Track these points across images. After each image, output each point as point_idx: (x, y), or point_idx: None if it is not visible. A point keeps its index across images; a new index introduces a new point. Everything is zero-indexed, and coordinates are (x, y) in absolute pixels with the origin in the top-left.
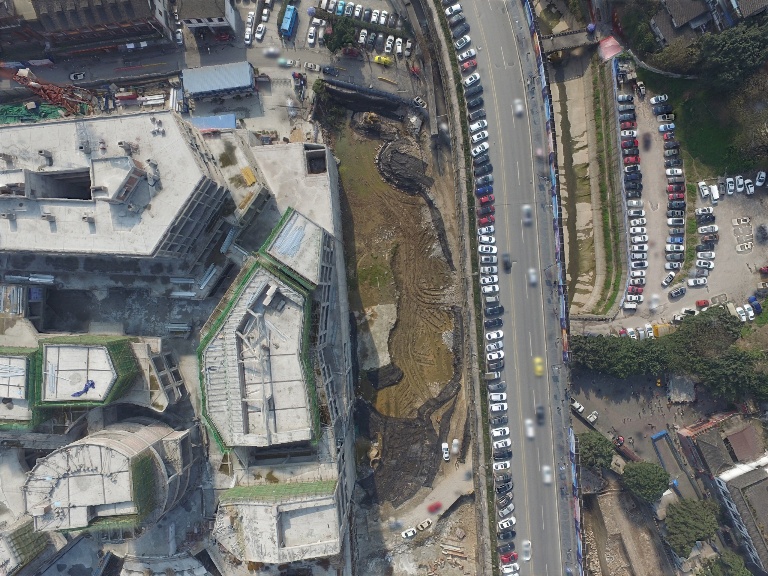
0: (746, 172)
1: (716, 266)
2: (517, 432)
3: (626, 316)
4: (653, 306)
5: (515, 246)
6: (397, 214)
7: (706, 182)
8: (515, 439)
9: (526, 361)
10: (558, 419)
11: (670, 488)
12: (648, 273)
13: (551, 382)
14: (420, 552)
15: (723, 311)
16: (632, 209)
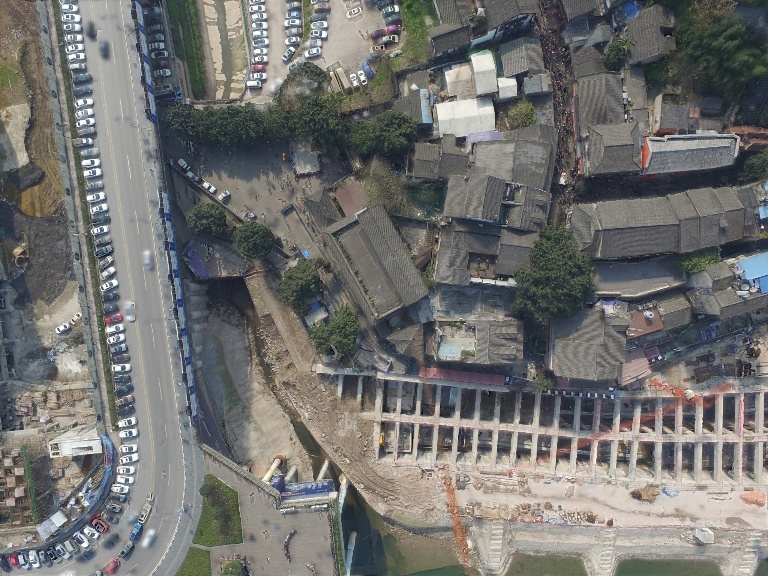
0: None
1: (330, 36)
2: (114, 197)
3: (253, 96)
4: (277, 84)
5: (99, 14)
6: (23, 13)
7: None
8: (112, 204)
9: (118, 127)
10: (152, 181)
11: (300, 258)
12: (271, 51)
13: (142, 145)
14: (82, 350)
15: None
16: None
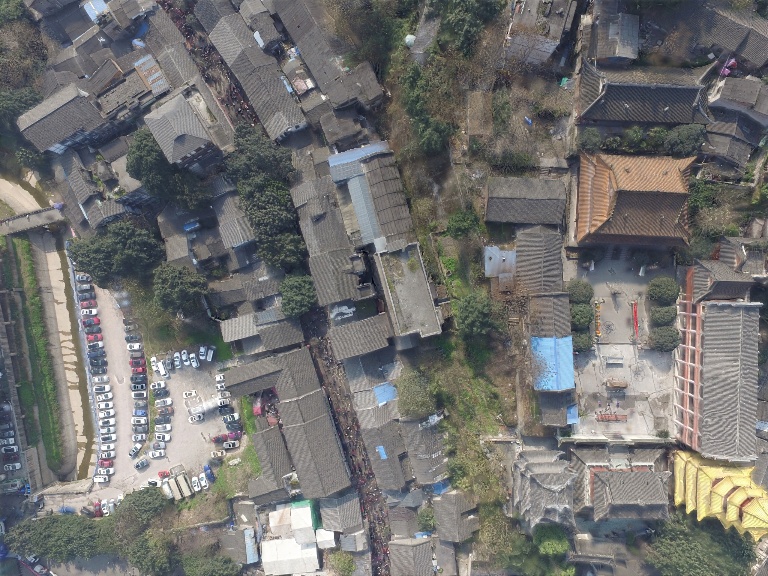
0: (192, 346)
1: (174, 437)
2: None
3: (102, 488)
4: (125, 477)
5: None
6: None
7: (158, 357)
8: None
9: None
10: None
11: None
12: (118, 445)
13: None
14: None
15: (138, 497)
16: (97, 385)
